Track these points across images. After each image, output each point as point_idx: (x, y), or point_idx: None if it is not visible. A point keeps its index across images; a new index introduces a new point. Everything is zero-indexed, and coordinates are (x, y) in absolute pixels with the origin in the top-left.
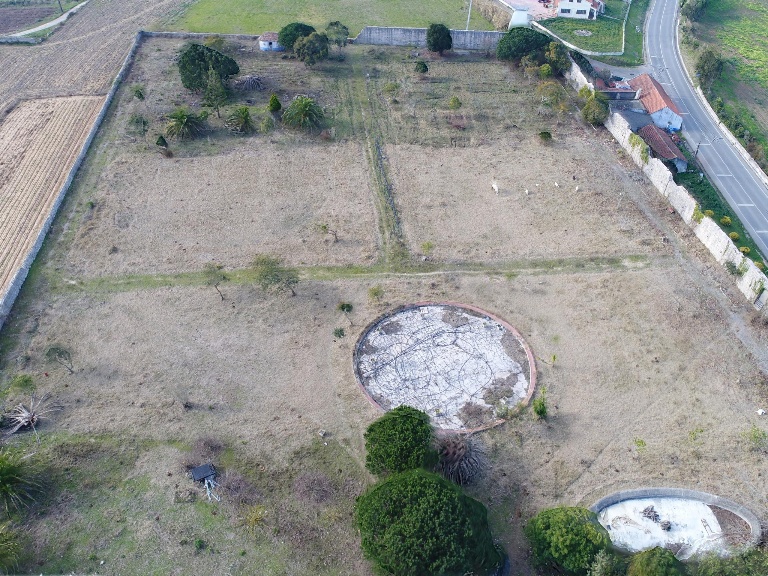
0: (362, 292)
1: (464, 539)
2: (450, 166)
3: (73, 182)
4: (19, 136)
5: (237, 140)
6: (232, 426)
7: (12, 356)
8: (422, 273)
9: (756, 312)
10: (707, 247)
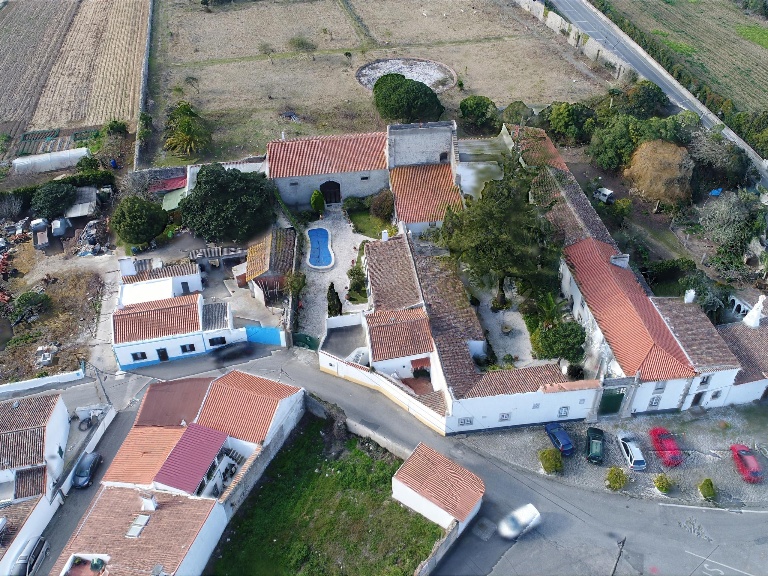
0: (354, 57)
1: (428, 94)
2: (395, 7)
3: (152, 26)
4: (97, 12)
5: (251, 3)
6: (298, 102)
7: (160, 90)
8: (387, 49)
9: (577, 49)
10: (552, 29)
